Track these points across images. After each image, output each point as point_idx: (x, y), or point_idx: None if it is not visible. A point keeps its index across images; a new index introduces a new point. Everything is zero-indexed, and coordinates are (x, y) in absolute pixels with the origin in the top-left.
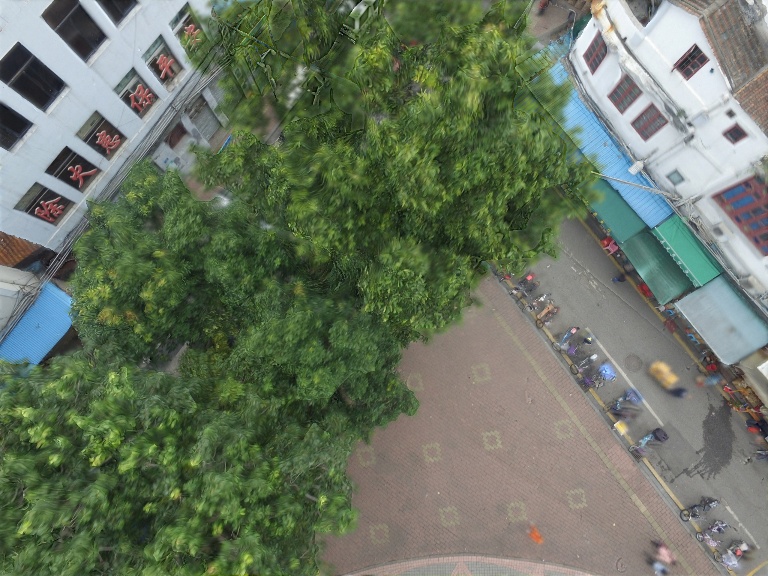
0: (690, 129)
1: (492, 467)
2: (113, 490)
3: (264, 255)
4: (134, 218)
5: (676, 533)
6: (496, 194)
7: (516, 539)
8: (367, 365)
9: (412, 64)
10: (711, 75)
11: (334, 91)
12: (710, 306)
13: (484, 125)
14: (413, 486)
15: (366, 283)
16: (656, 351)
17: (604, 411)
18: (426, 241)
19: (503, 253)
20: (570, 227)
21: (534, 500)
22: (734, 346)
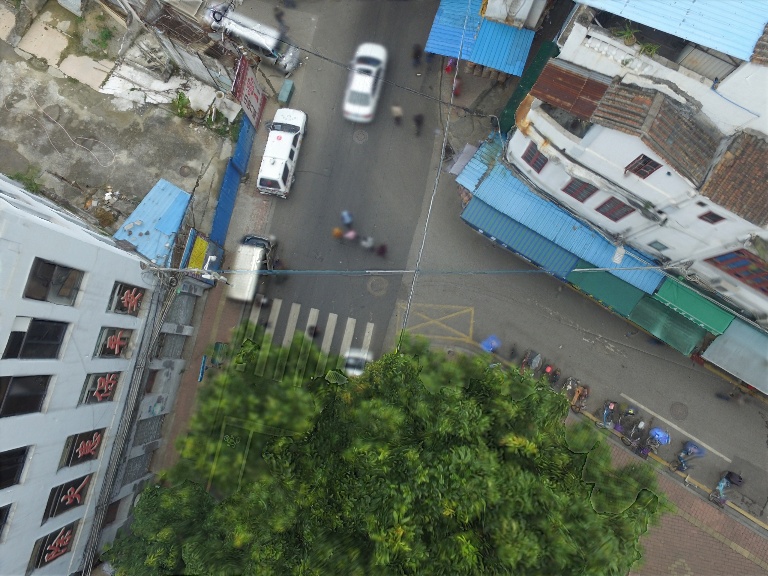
0: (662, 216)
1: None
2: None
3: None
4: (160, 572)
5: None
6: None
7: None
8: None
9: (439, 503)
10: (669, 177)
11: (284, 252)
12: (736, 348)
13: None
14: None
15: None
16: (695, 390)
17: (671, 471)
18: None
19: None
20: (565, 299)
21: None
22: None
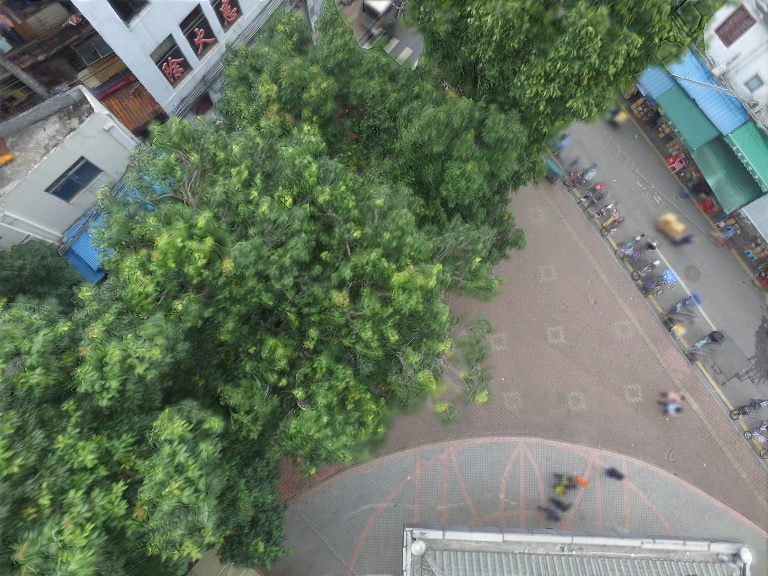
0: None
1: (555, 359)
2: None
3: (404, 83)
4: None
5: (725, 431)
6: None
7: (574, 425)
8: (509, 165)
9: None
10: None
11: None
12: None
13: None
14: None
15: (524, 77)
16: (714, 264)
17: (662, 315)
18: (605, 9)
19: (666, 31)
20: (637, 145)
21: (593, 391)
22: None
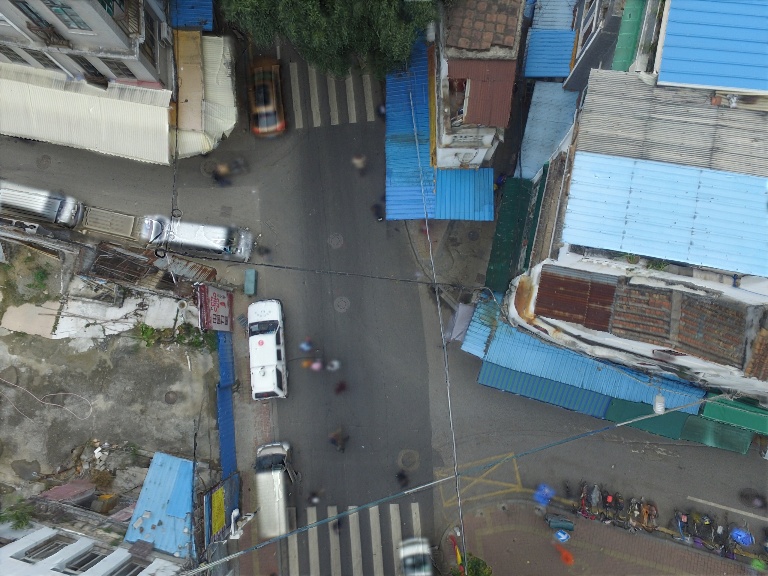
0: (700, 375)
1: None
2: None
3: None
4: None
5: None
6: None
7: None
8: None
9: None
10: None
11: (301, 454)
12: None
13: None
14: None
15: None
16: (758, 470)
17: (762, 564)
18: None
19: None
20: None
21: None
22: None
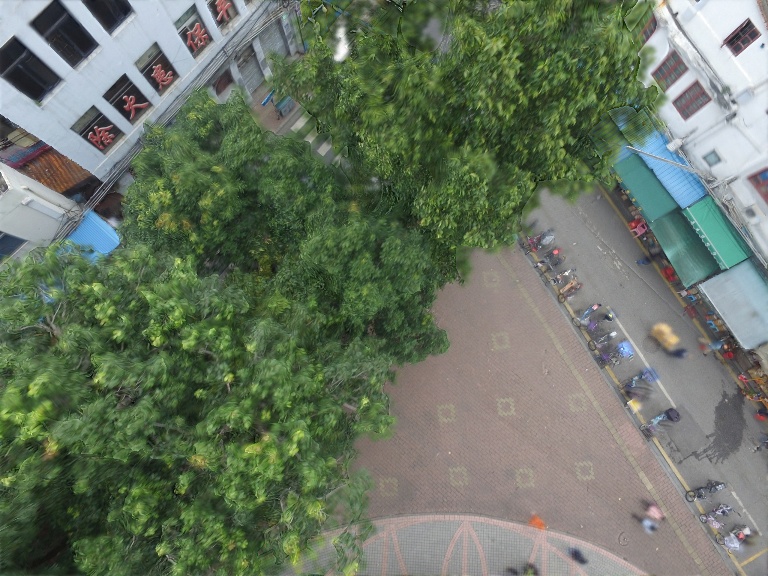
0: (733, 107)
1: (504, 433)
2: (170, 369)
3: (316, 181)
4: (191, 140)
5: (680, 513)
6: (569, 101)
7: (522, 504)
8: (413, 285)
9: None
10: (761, 50)
11: None
12: (734, 289)
13: (570, 23)
14: (425, 444)
15: (422, 201)
16: (674, 335)
17: (618, 388)
18: (492, 150)
19: (563, 171)
20: (599, 207)
21: (543, 468)
22: (755, 330)
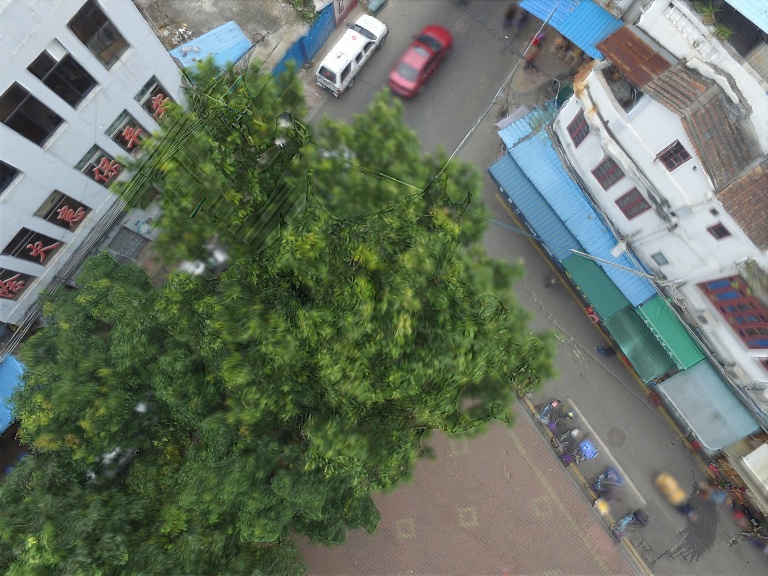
0: (673, 219)
1: (467, 545)
2: None
3: None
4: (84, 319)
5: None
6: None
7: None
8: (313, 509)
9: (344, 245)
10: (694, 172)
11: None
12: (694, 389)
13: (411, 342)
14: (385, 564)
15: (309, 433)
16: (640, 424)
17: (585, 487)
18: (363, 421)
19: (448, 428)
20: (554, 292)
21: None
22: (718, 432)
